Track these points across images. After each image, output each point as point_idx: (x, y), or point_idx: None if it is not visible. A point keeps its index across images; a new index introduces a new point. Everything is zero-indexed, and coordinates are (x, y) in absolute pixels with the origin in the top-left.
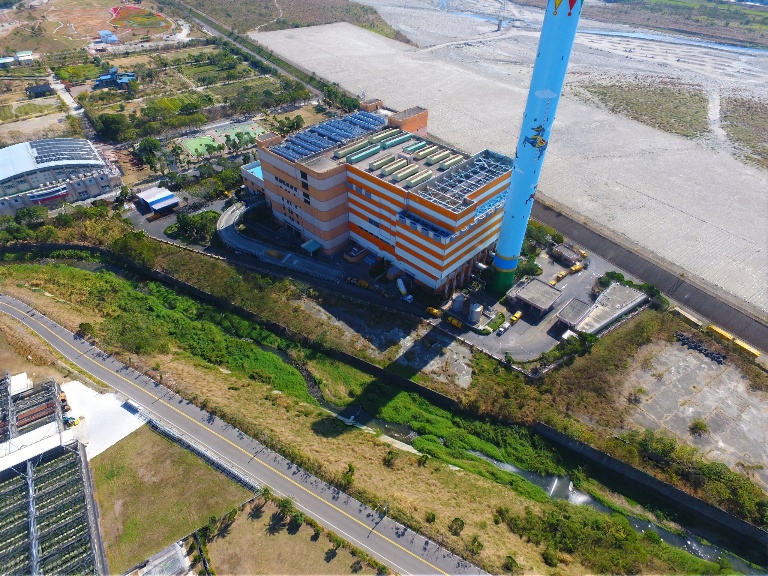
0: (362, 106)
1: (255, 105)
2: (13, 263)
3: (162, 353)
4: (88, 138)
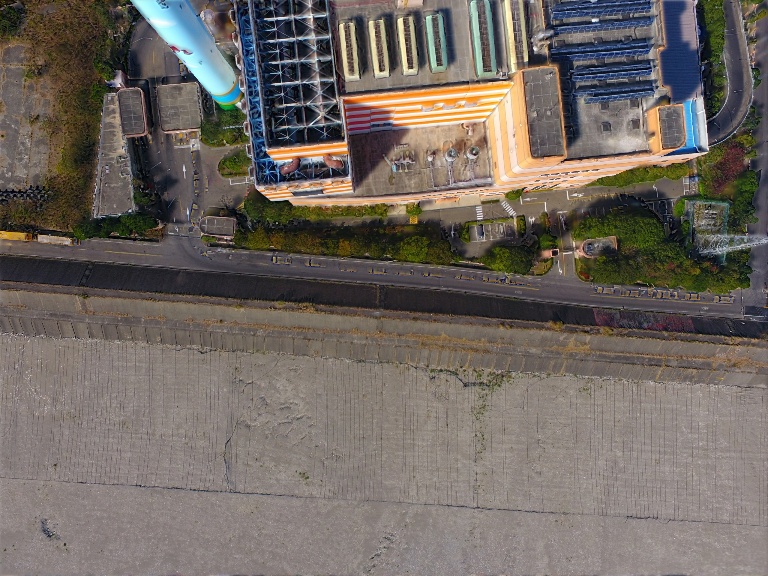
0: None
1: None
2: None
3: None
4: None
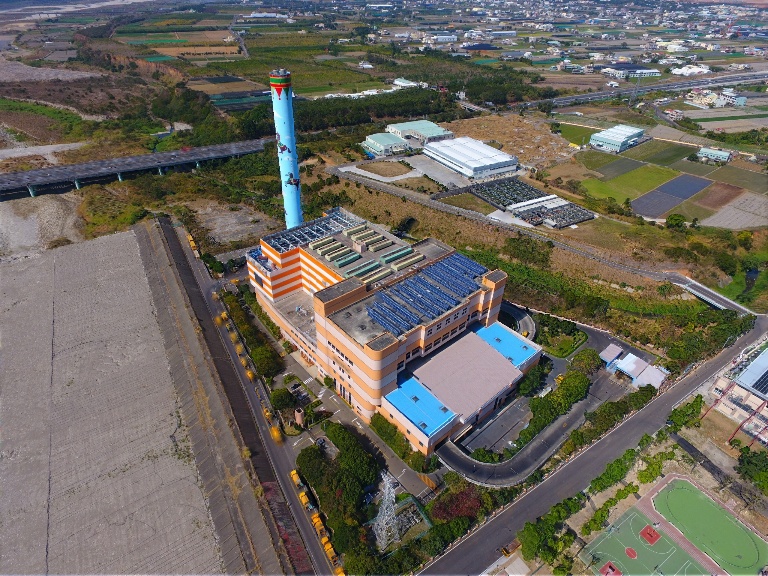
0: None
1: None
2: None
3: None
4: None
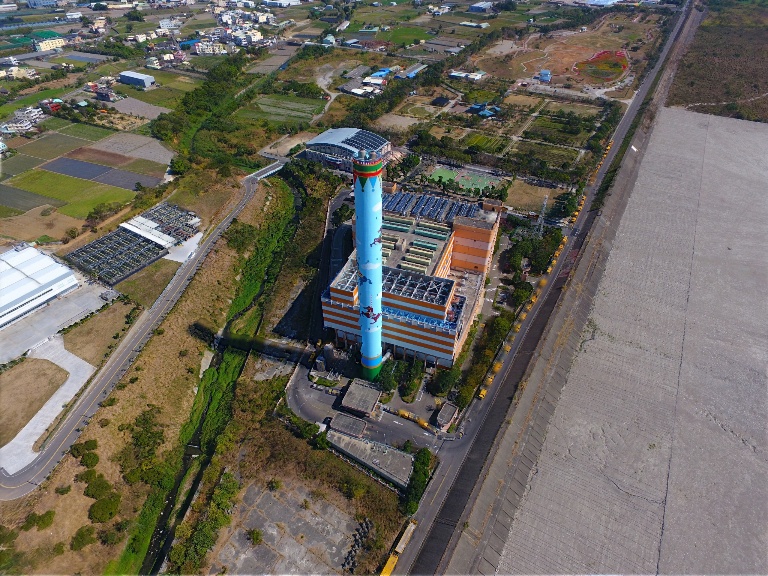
0: None
1: (515, 168)
2: (288, 183)
3: (237, 251)
4: (408, 141)
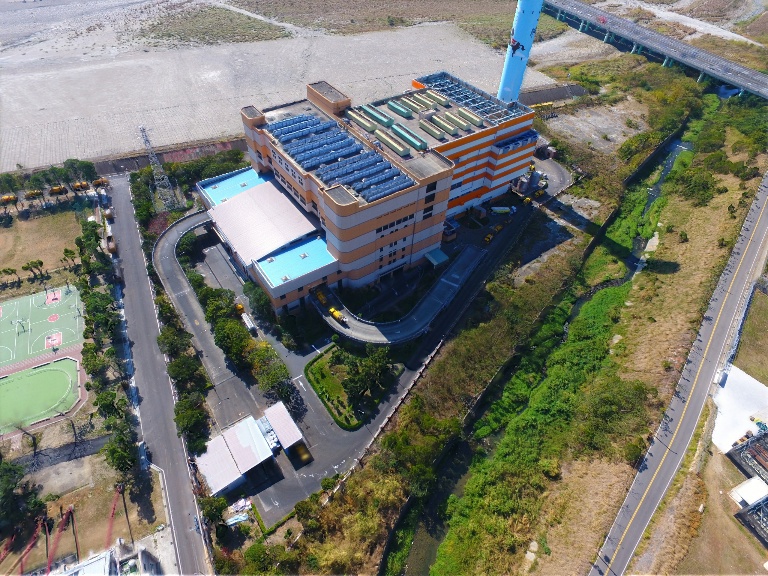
0: (254, 122)
1: None
2: None
3: None
4: None
